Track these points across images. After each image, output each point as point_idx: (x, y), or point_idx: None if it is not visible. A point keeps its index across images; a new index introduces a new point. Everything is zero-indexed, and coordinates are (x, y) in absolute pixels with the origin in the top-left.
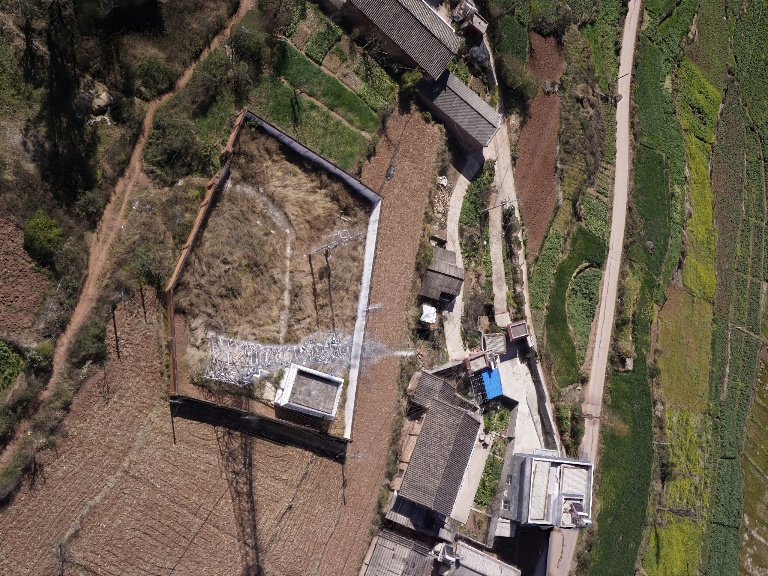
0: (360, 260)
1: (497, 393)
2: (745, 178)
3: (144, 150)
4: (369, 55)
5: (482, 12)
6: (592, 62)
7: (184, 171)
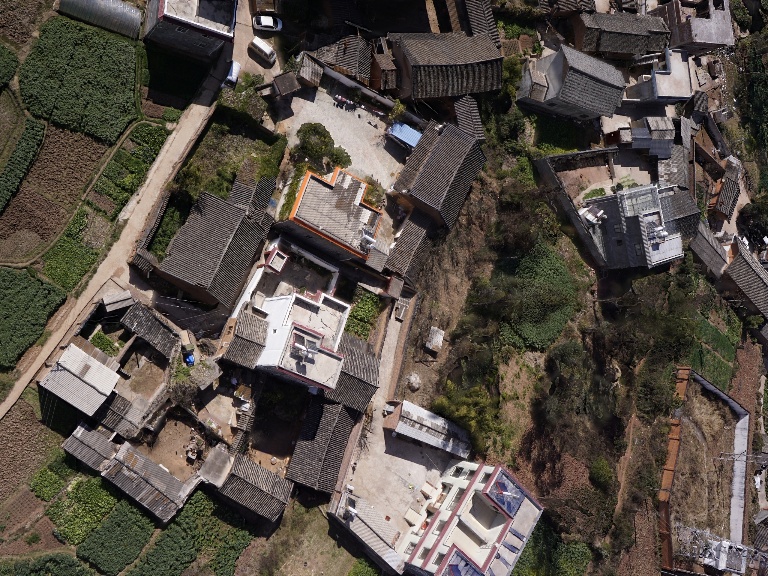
0: None
1: None
2: None
3: (636, 401)
4: None
5: None
6: None
7: (658, 414)
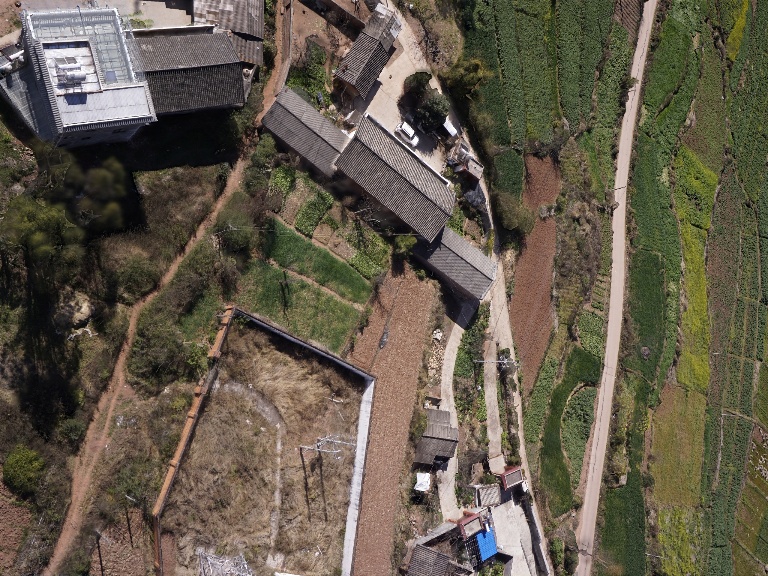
0: (353, 441)
1: (492, 553)
2: (740, 257)
3: (128, 359)
4: (361, 219)
5: (477, 148)
6: (589, 174)
7: (170, 378)
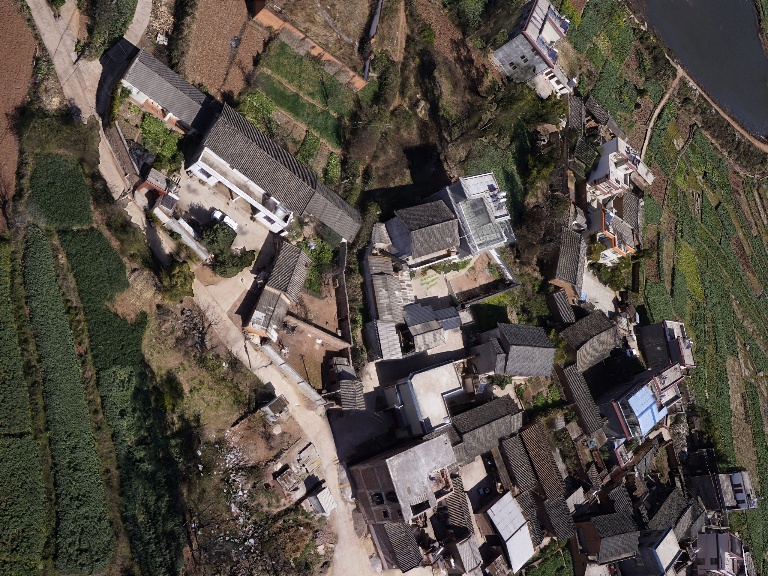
0: None
1: None
2: None
3: None
4: None
5: None
6: None
7: None
